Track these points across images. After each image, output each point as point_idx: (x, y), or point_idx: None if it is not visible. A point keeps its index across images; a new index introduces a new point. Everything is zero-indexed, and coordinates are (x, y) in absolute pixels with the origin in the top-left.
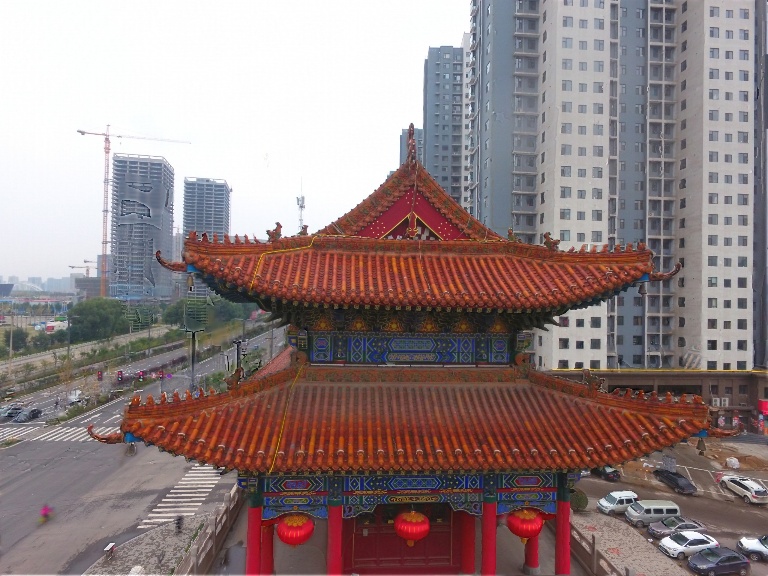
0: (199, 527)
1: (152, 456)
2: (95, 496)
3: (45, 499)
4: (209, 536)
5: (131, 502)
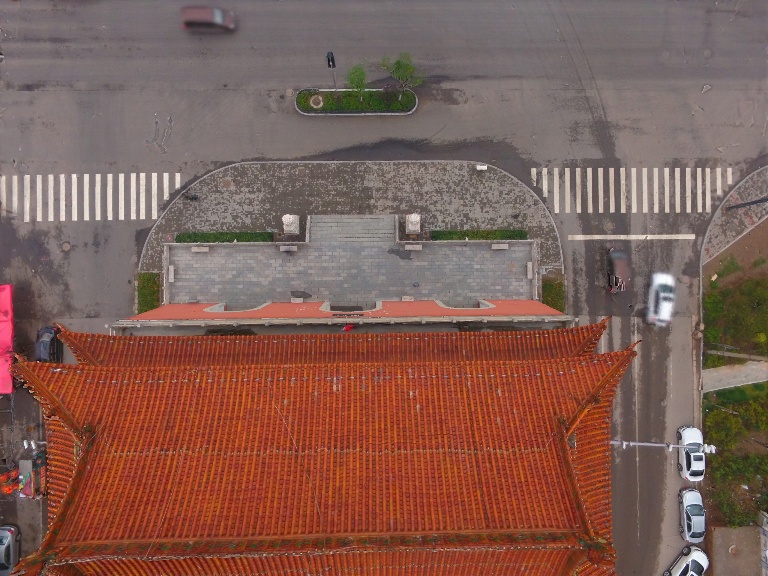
0: (517, 230)
1: (718, 101)
2: (599, 93)
3: (594, 45)
4: (228, 324)
5: (584, 138)
